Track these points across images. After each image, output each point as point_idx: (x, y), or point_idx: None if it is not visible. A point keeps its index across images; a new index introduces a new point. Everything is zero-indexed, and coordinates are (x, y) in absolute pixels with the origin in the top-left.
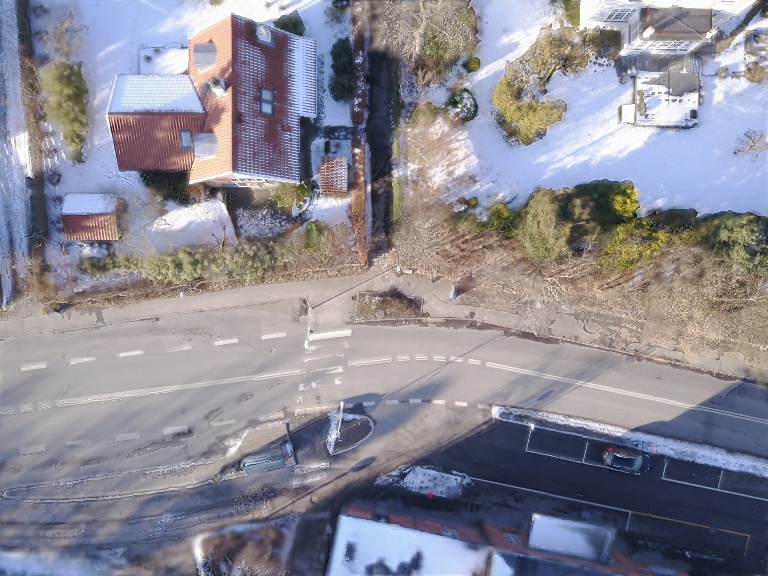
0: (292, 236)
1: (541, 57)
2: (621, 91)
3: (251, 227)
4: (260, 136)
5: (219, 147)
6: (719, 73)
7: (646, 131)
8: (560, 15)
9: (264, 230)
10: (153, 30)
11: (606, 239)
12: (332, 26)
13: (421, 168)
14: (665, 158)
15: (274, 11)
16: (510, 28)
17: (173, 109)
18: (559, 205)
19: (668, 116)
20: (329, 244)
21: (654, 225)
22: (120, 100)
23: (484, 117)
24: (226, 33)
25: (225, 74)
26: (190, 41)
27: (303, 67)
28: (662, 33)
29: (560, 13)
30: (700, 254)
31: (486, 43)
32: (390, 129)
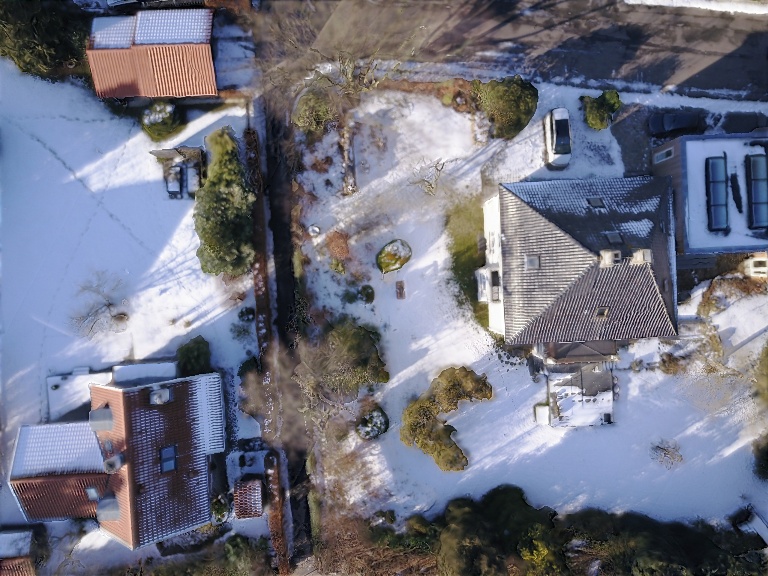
0: (213, 547)
1: (441, 405)
2: (535, 389)
3: (172, 537)
4: (163, 498)
5: (121, 516)
6: (633, 367)
7: (563, 427)
8: (469, 317)
9: (186, 538)
10: (60, 355)
11: (519, 575)
12: (240, 339)
13: (337, 480)
14: (583, 454)
15: (180, 328)
16: (418, 335)
17: (75, 470)
18: (466, 557)
19: (582, 417)
20: (247, 567)
21: (573, 531)
22: (22, 461)
23: (397, 426)
24: (119, 408)
25: (121, 449)
26: (91, 389)
27: (207, 405)
28: (566, 357)
29: (469, 315)
30: (617, 575)
31: (395, 351)
32: (305, 435)
